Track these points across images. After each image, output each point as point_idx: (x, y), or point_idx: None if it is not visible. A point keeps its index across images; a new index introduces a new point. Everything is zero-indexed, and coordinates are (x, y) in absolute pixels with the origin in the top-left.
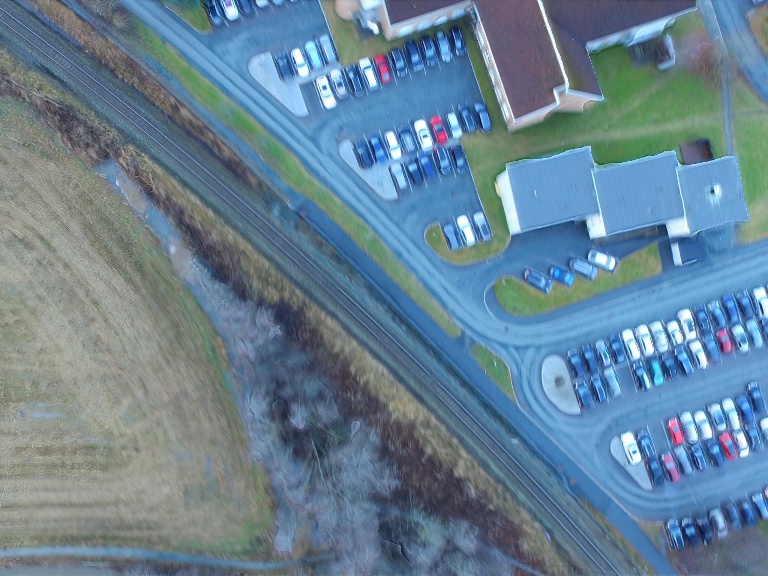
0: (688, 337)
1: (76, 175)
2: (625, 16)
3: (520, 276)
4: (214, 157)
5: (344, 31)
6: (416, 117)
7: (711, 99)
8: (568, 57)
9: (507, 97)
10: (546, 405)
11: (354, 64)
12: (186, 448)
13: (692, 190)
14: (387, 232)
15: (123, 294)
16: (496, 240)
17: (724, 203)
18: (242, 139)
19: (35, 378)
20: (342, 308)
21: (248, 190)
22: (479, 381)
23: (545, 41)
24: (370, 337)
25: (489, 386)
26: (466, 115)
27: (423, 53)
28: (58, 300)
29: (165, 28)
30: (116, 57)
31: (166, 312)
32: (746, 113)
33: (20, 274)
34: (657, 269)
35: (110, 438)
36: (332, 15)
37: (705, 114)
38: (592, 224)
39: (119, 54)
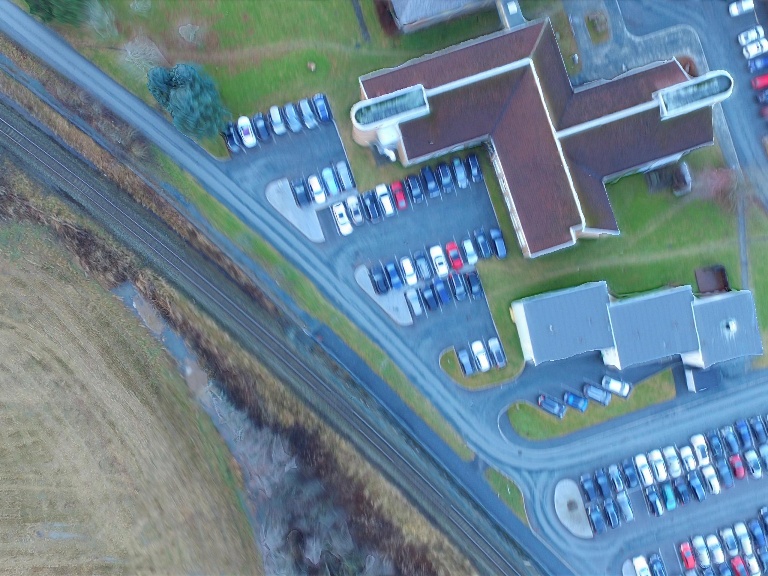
0: (701, 463)
1: (94, 297)
2: (642, 152)
3: (534, 401)
4: (231, 280)
5: (361, 157)
6: (432, 243)
7: (727, 224)
8: (585, 194)
9: (523, 232)
10: (559, 528)
11: (371, 190)
12: (201, 568)
13: (707, 325)
14: (402, 357)
15: (139, 416)
16: (510, 365)
17: (739, 337)
18: (259, 265)
19: (52, 498)
20: (356, 431)
21: (264, 313)
22: (492, 505)
23: (562, 181)
24: (384, 459)
25: (502, 510)
26: (482, 241)
27: (439, 180)
28: (75, 421)
29: (183, 155)
30: (134, 183)
31: (182, 434)
32: (762, 238)
33: (38, 396)
34: (671, 394)
35: (126, 558)
36: (349, 141)
37: (720, 239)
38: (607, 353)
39: (137, 181)
